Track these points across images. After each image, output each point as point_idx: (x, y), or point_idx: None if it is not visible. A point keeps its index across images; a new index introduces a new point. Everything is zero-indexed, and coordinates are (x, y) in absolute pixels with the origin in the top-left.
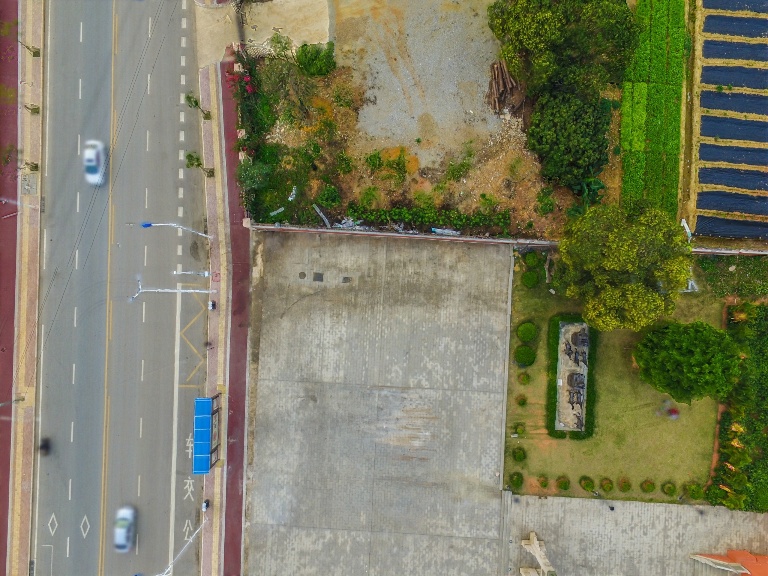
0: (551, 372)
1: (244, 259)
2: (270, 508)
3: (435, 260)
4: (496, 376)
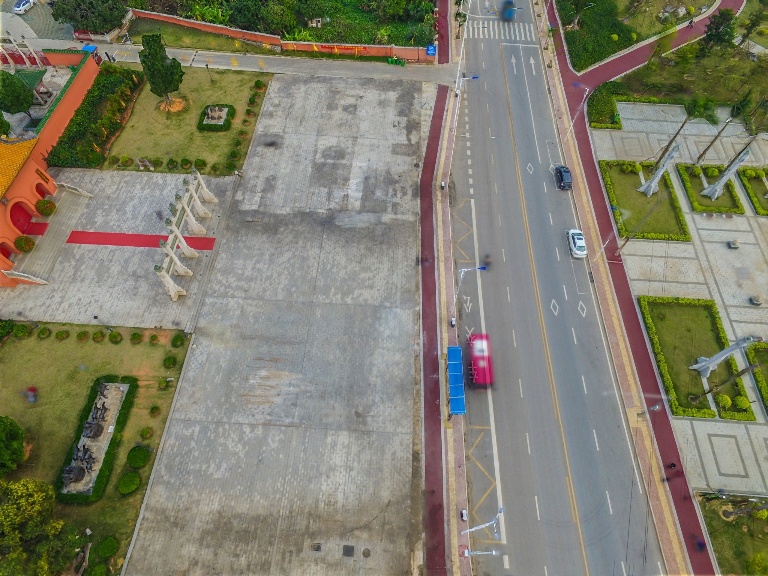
0: (117, 440)
1: (433, 575)
2: (398, 320)
3: (213, 573)
4: (174, 436)
